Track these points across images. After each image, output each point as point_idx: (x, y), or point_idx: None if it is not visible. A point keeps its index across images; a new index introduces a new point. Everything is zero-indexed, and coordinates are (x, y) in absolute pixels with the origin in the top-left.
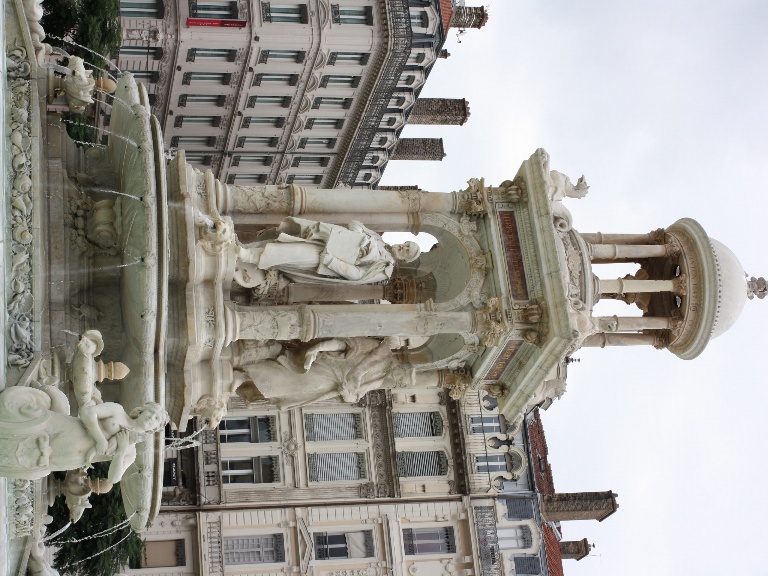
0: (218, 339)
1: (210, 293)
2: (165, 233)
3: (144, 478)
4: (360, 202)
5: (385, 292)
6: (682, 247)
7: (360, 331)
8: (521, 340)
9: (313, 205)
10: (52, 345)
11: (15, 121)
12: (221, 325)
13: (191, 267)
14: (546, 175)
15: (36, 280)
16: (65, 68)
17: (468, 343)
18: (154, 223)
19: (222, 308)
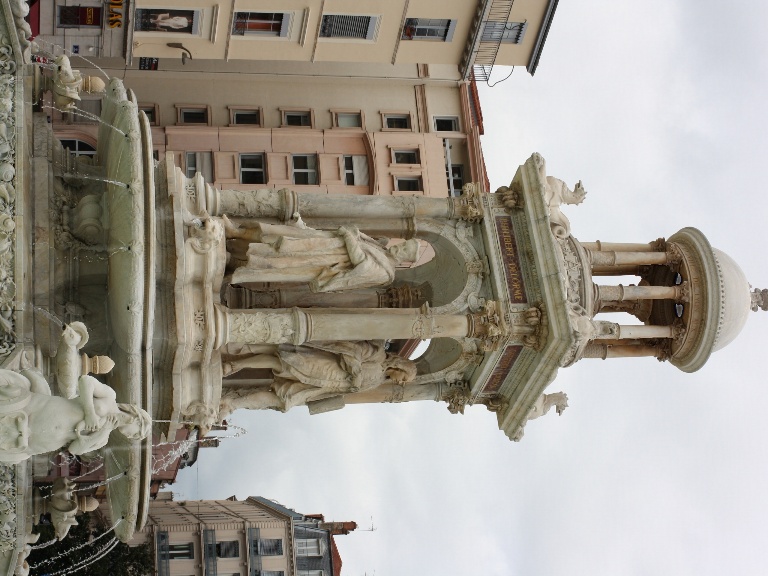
0: (197, 176)
1: None
2: None
3: (129, 108)
4: None
5: (378, 292)
6: None
7: None
8: (507, 218)
9: None
10: None
11: None
12: None
13: None
14: None
15: None
16: None
17: None
18: None
19: None
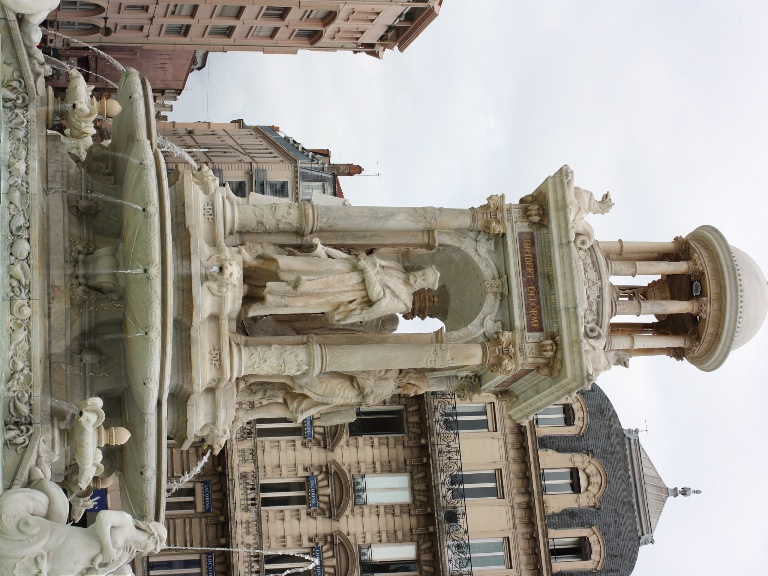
0: (215, 193)
1: None
2: None
3: (146, 168)
4: None
5: None
6: None
7: (359, 210)
8: (530, 234)
9: None
10: None
11: None
12: None
13: None
14: None
15: None
16: None
17: (488, 280)
18: None
19: None
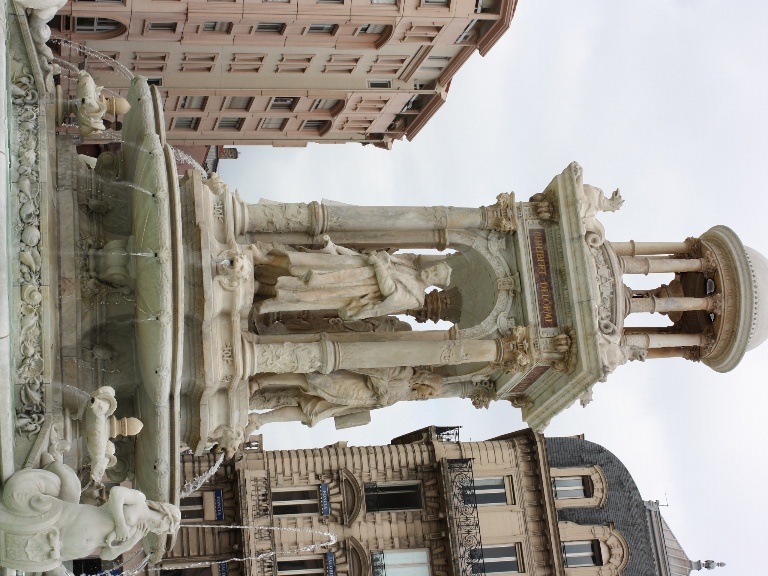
0: (225, 193)
1: None
2: None
3: (155, 156)
4: None
5: None
6: None
7: (369, 209)
8: (541, 231)
9: None
10: None
11: None
12: None
13: None
14: None
15: None
16: None
17: (500, 277)
18: None
19: None
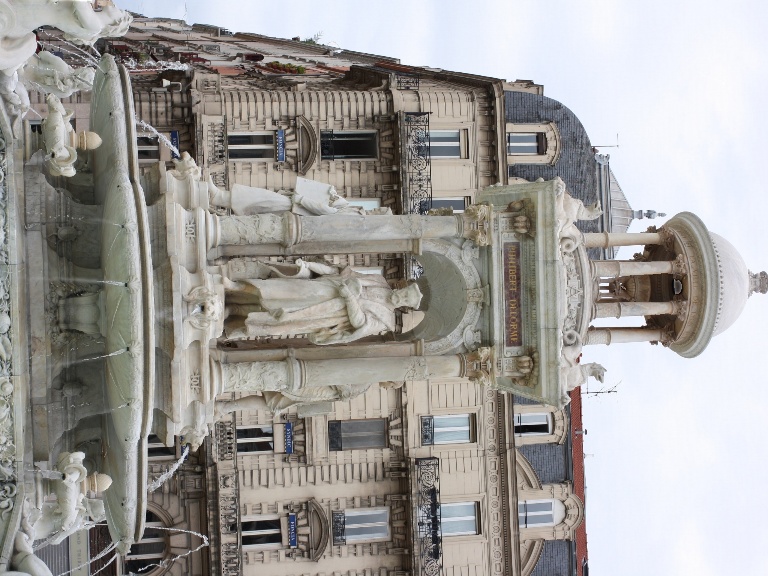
0: (197, 211)
1: None
2: (126, 73)
3: (128, 232)
4: None
5: None
6: None
7: (344, 222)
8: (516, 244)
9: None
10: None
11: None
12: None
13: (161, 166)
14: None
15: None
16: None
17: (470, 288)
18: None
19: None
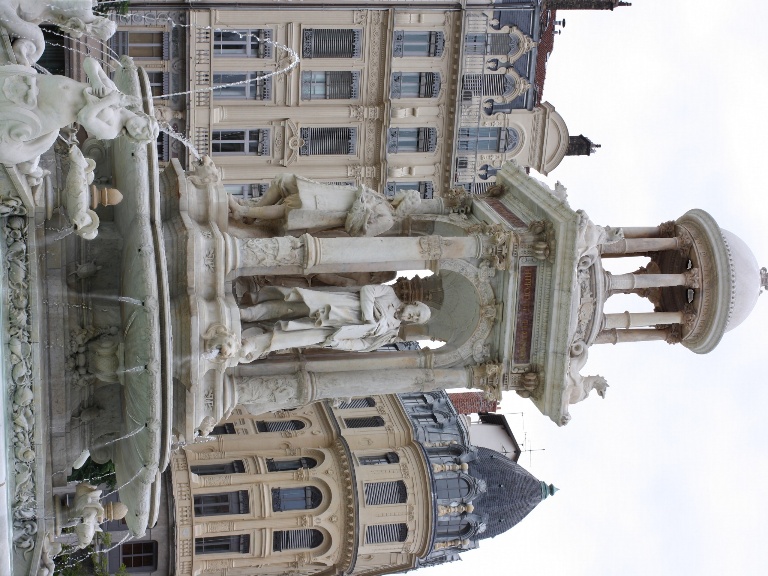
0: None
1: (211, 374)
2: (168, 440)
3: None
4: (377, 259)
5: None
6: (703, 282)
7: None
8: None
9: (327, 263)
10: (53, 472)
11: (13, 325)
12: (219, 409)
13: (193, 387)
14: (580, 238)
15: (39, 495)
16: (66, 230)
17: None
18: (158, 441)
19: (222, 390)
